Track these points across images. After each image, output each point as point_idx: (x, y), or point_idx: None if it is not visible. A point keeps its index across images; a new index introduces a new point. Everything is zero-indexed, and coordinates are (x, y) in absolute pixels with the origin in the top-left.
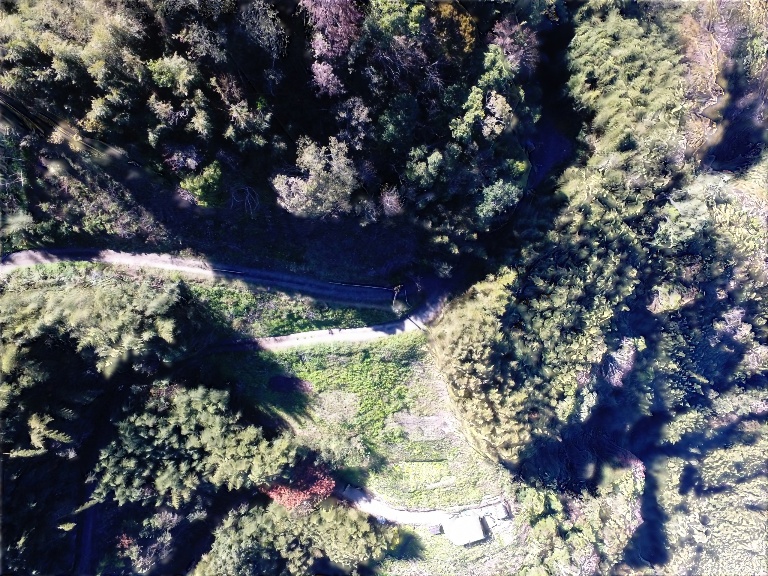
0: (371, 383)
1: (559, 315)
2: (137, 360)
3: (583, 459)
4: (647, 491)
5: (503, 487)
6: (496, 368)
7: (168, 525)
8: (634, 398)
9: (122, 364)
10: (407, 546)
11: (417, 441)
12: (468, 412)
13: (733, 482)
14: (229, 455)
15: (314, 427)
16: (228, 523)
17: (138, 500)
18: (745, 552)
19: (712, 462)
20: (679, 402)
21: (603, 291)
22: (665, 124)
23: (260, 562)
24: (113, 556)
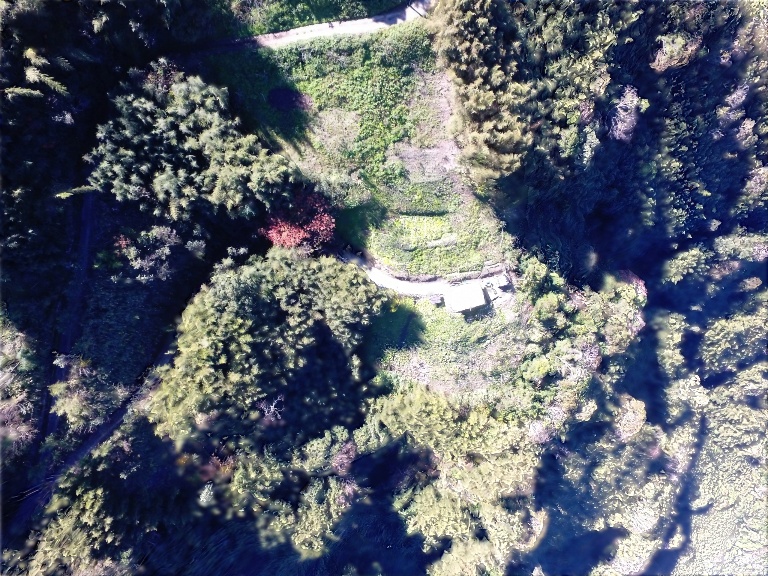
0: (372, 96)
1: (562, 14)
2: (134, 18)
3: (585, 248)
4: (648, 349)
5: (505, 254)
6: (499, 38)
7: (166, 237)
8: (636, 200)
9: (119, 19)
10: (408, 328)
11: (418, 183)
12: (470, 100)
13: (734, 366)
14: (228, 157)
15: (314, 157)
16: (227, 261)
17: (136, 199)
18: (745, 462)
19: (713, 336)
20: (681, 230)
21: (607, 7)
22: None
23: (260, 303)
24: (111, 254)
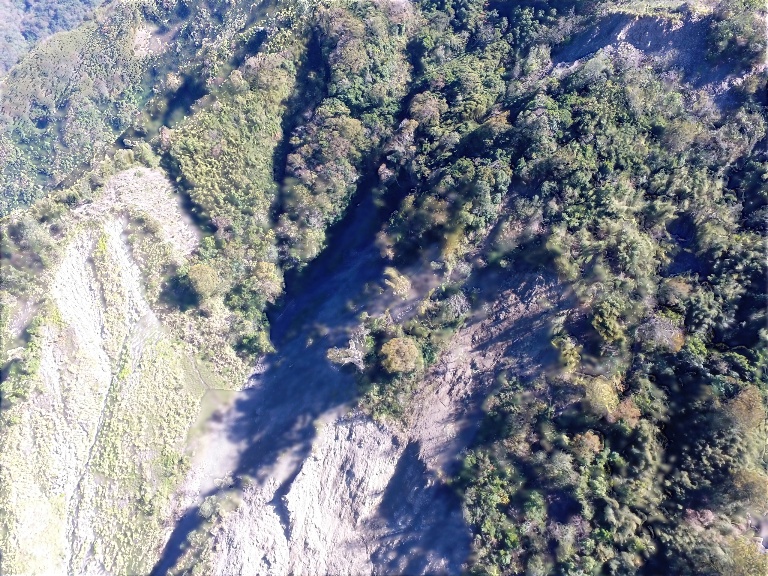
0: None
1: None
2: None
3: None
4: None
5: None
6: None
7: None
8: None
9: None
10: None
11: None
12: None
13: None
14: None
15: None
16: None
17: None
18: None
19: None
20: None
21: None
22: (327, 0)
23: None
24: None
